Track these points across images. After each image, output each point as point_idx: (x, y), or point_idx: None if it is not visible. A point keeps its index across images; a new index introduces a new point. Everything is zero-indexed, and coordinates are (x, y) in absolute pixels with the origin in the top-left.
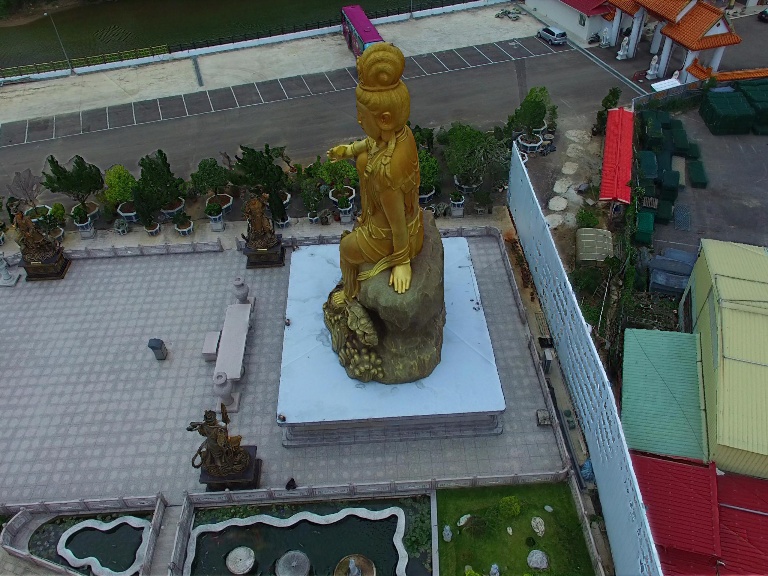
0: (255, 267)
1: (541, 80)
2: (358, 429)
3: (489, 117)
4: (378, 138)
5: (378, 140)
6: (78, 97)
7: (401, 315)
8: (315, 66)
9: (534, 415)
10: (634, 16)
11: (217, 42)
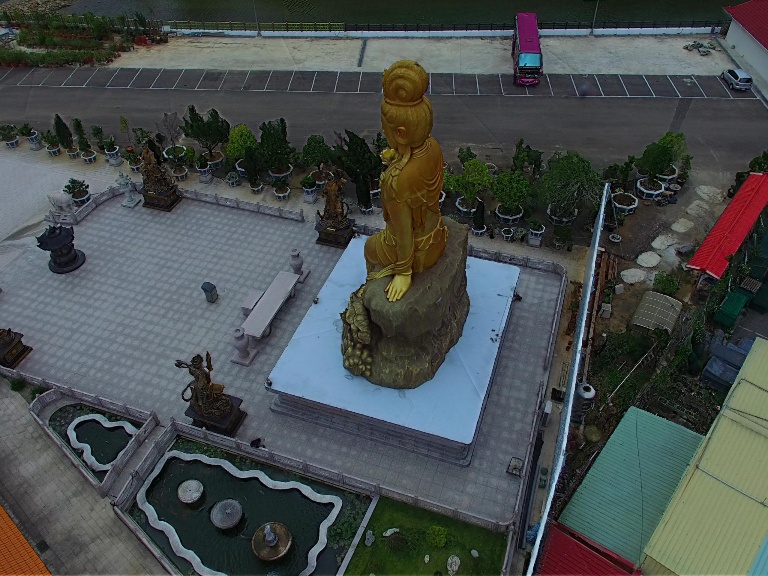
0: (323, 243)
1: (699, 125)
2: (336, 416)
3: (621, 152)
4: (396, 150)
5: (397, 151)
6: (253, 57)
7: (386, 322)
8: (471, 67)
9: (508, 461)
10: None
11: (390, 28)
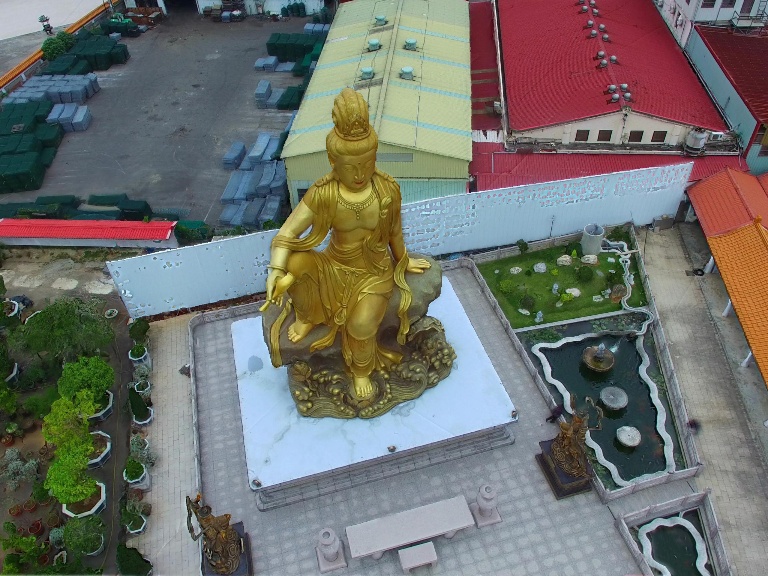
0: (253, 573)
1: None
2: None
3: None
4: None
5: None
6: None
7: None
8: None
9: None
10: None
11: None
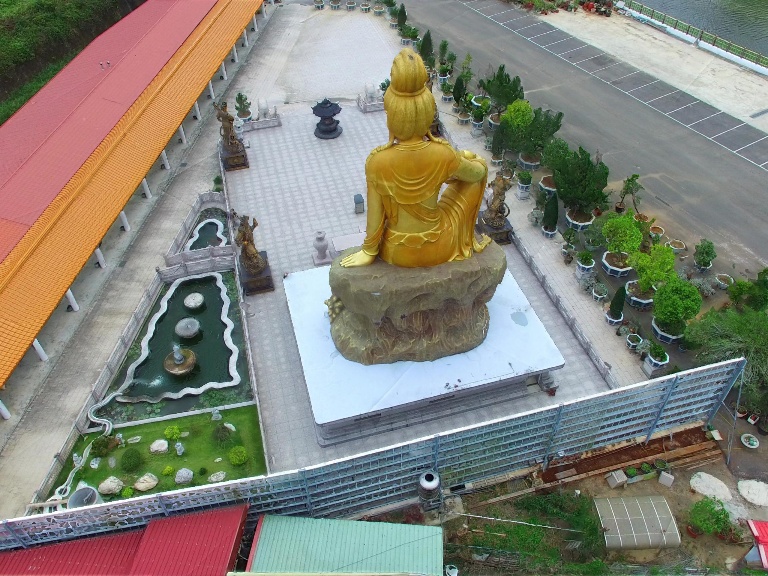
0: None
1: None
2: None
3: None
4: None
5: None
6: (661, 61)
7: None
8: None
9: None
10: None
11: None
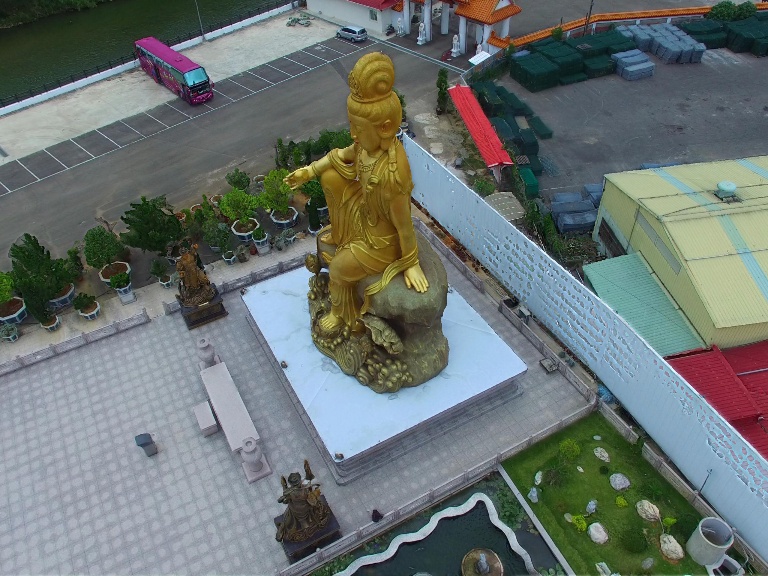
0: (198, 326)
1: None
2: (404, 439)
3: (338, 120)
4: (376, 148)
5: (375, 150)
6: None
7: (430, 313)
8: (130, 108)
9: (539, 367)
10: (425, 3)
11: None
